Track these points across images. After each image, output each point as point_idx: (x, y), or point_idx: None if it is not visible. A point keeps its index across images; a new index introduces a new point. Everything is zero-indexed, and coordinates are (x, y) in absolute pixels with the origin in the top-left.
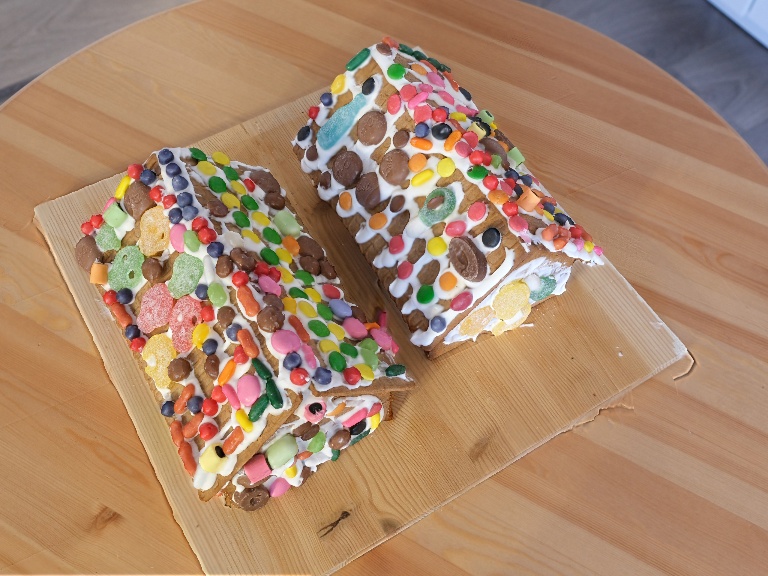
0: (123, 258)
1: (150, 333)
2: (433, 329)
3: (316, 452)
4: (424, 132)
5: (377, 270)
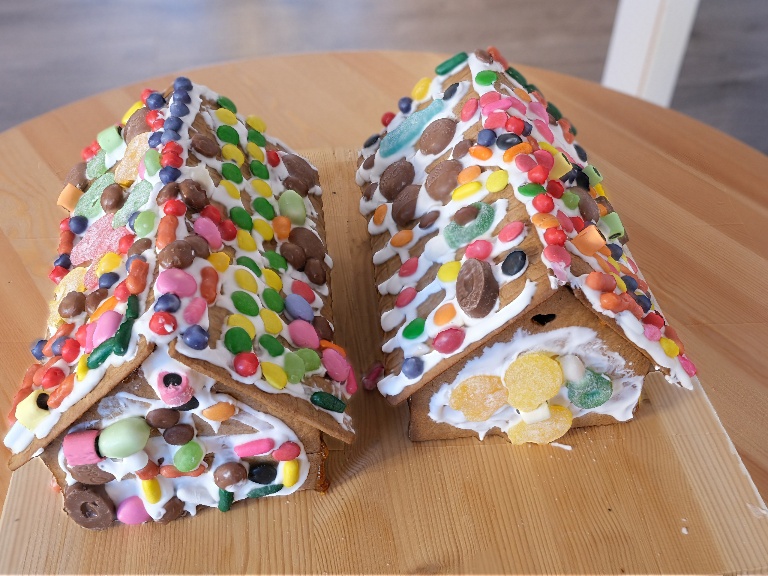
0: (99, 186)
1: (77, 266)
2: (403, 370)
3: (184, 472)
4: (488, 139)
5: (380, 297)
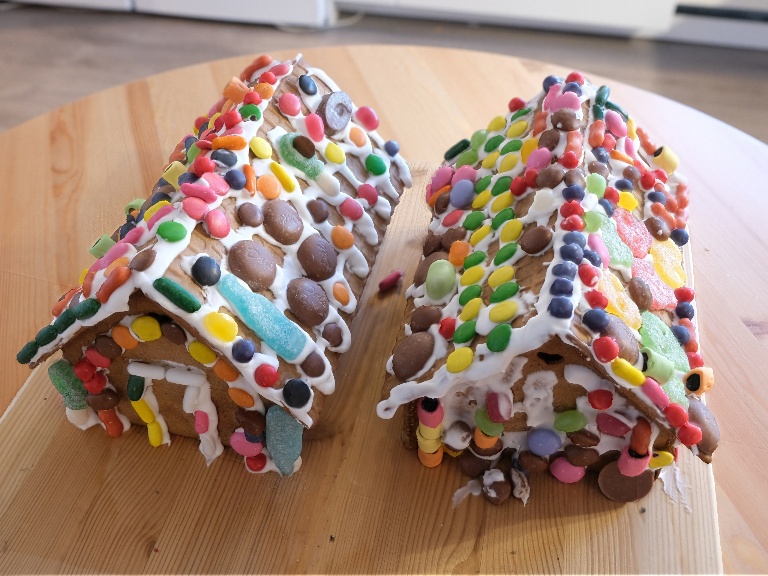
0: None
1: None
2: None
3: None
4: None
5: None
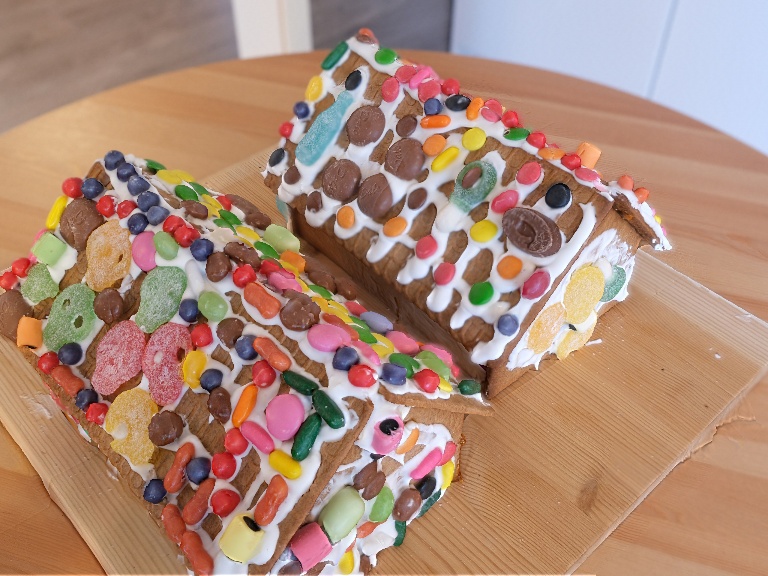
0: (63, 305)
1: (113, 393)
2: (503, 331)
3: (381, 521)
4: (437, 107)
5: (404, 288)
